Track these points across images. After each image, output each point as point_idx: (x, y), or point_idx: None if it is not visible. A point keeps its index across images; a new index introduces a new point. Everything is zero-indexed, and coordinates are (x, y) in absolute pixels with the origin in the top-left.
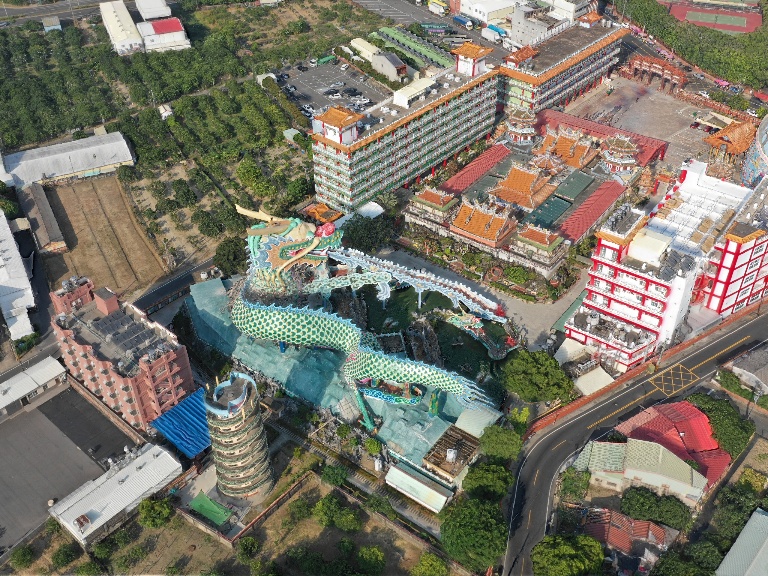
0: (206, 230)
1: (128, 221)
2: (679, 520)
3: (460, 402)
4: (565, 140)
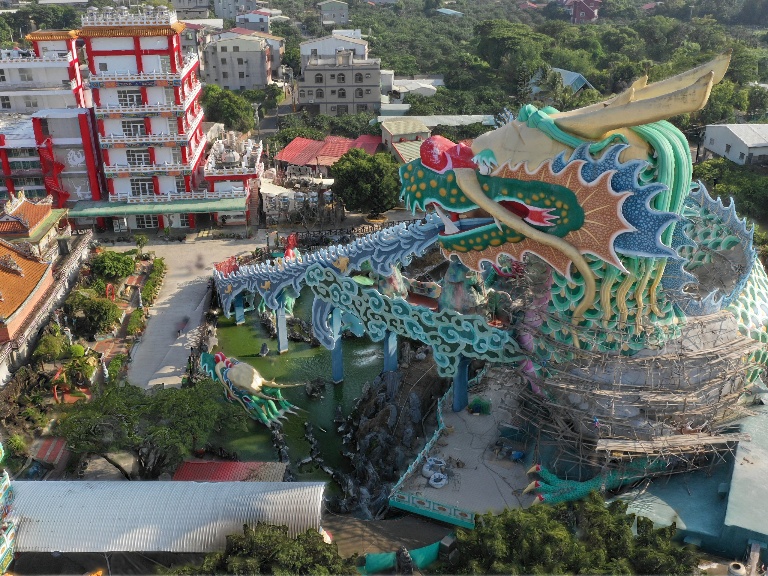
0: None
1: None
2: None
3: None
4: None
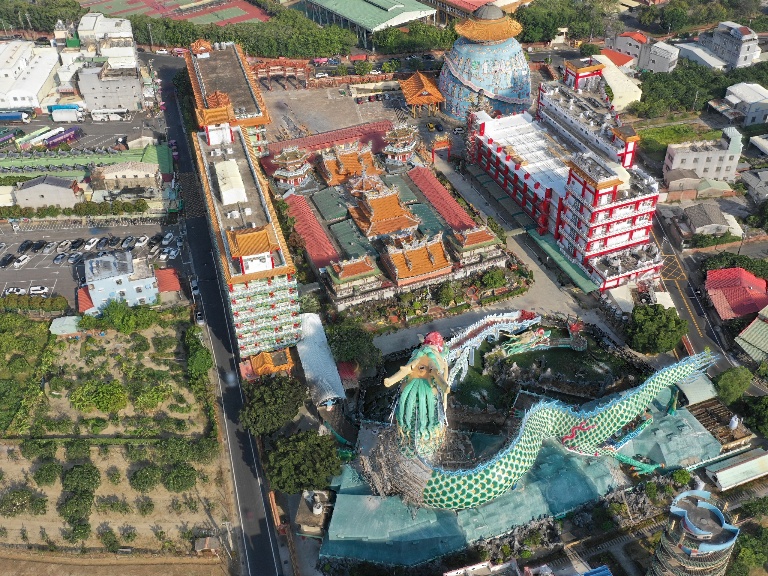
0: (185, 483)
1: (55, 568)
2: None
3: (684, 383)
4: (347, 157)
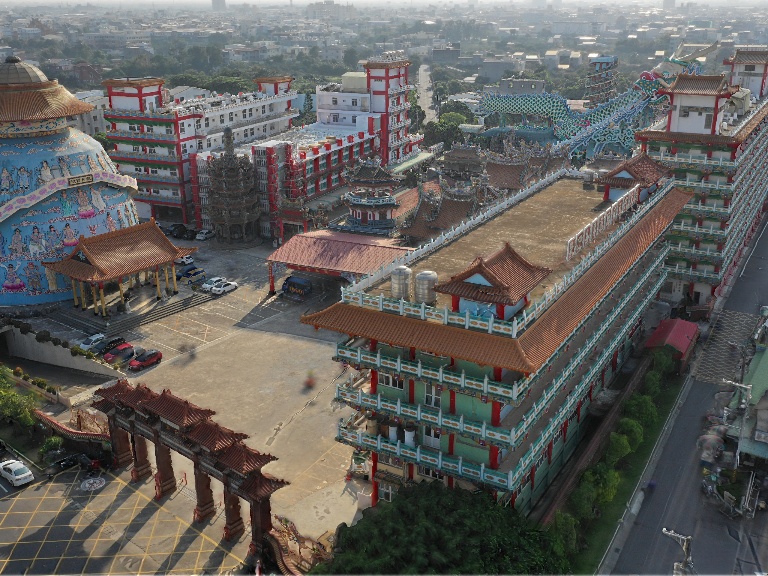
0: None
1: None
2: None
3: None
4: None
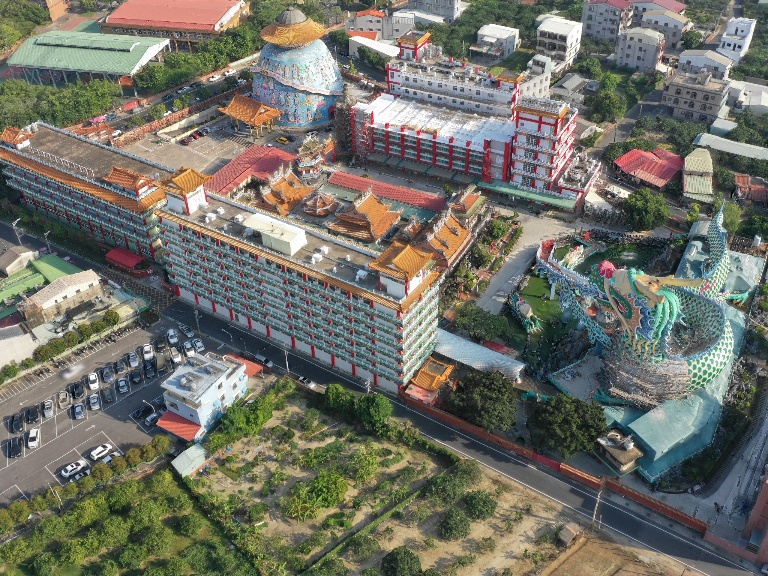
0: None
1: None
2: (723, 168)
3: None
4: (279, 185)
